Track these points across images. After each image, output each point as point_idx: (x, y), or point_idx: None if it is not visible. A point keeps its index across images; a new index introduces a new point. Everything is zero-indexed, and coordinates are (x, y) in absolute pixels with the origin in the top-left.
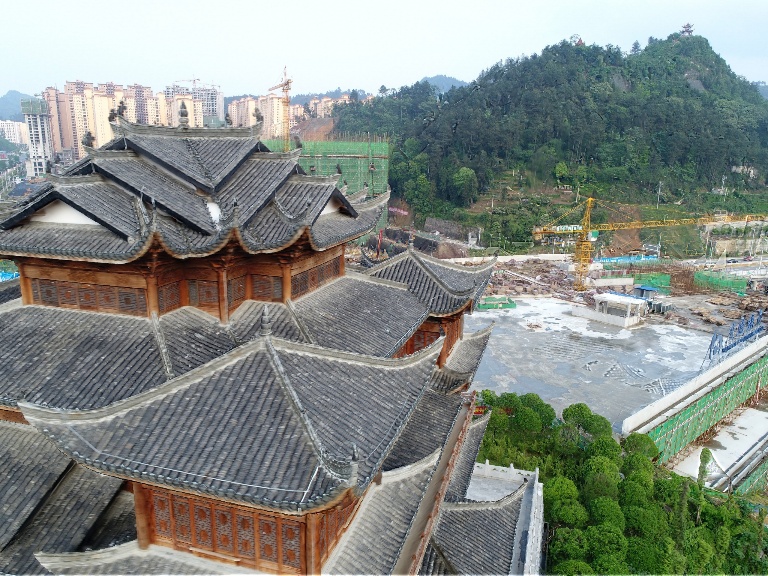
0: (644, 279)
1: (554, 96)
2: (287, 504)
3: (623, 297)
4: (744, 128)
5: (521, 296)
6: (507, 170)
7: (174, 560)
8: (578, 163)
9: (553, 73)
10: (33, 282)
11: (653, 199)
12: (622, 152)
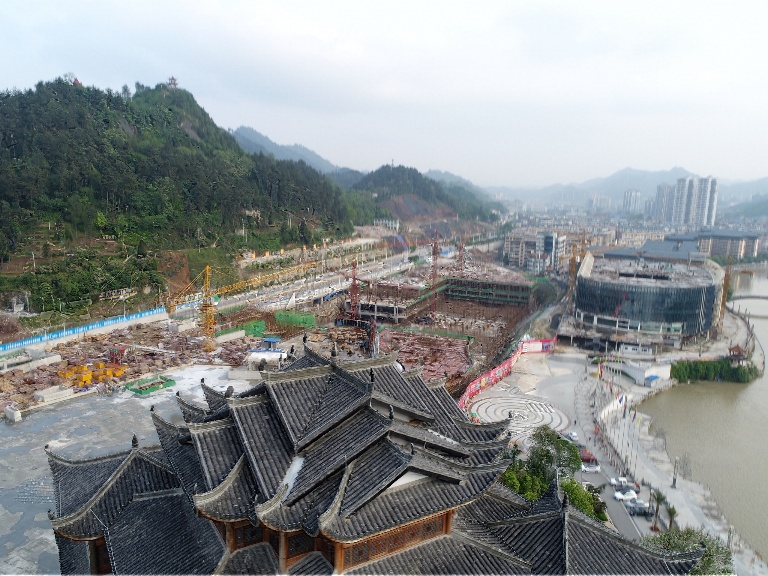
0: (245, 328)
1: (72, 141)
2: None
3: (268, 354)
4: (243, 177)
5: (167, 370)
6: (42, 223)
7: None
8: (115, 212)
9: (60, 114)
10: (346, 550)
11: (194, 244)
12: (157, 201)
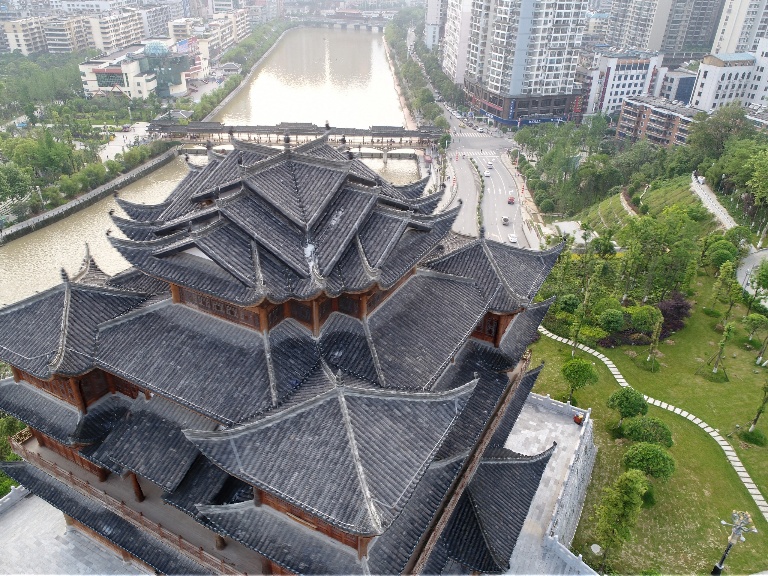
0: None
1: None
2: None
3: None
4: None
5: None
6: None
7: None
8: None
9: None
10: None
11: None
12: None
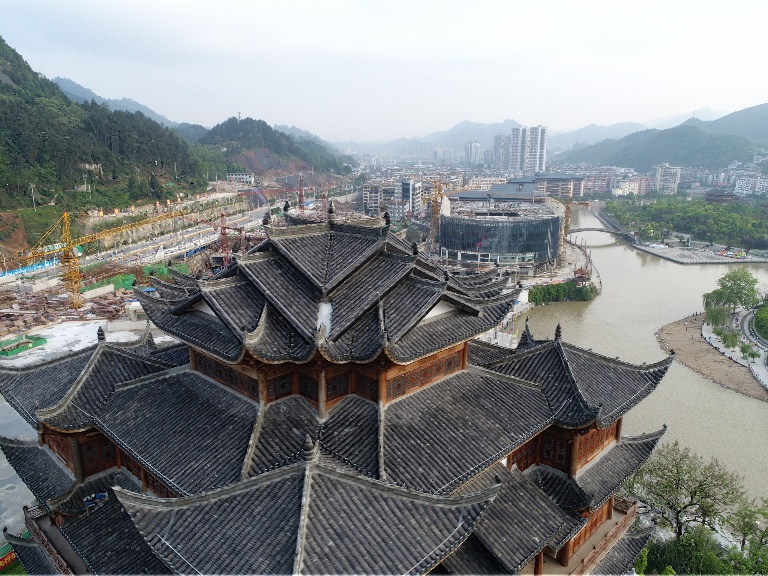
0: (112, 283)
1: None
2: (652, 389)
3: None
4: (77, 127)
5: (31, 330)
6: None
7: (583, 473)
8: None
9: None
10: (388, 383)
11: (27, 202)
12: None
